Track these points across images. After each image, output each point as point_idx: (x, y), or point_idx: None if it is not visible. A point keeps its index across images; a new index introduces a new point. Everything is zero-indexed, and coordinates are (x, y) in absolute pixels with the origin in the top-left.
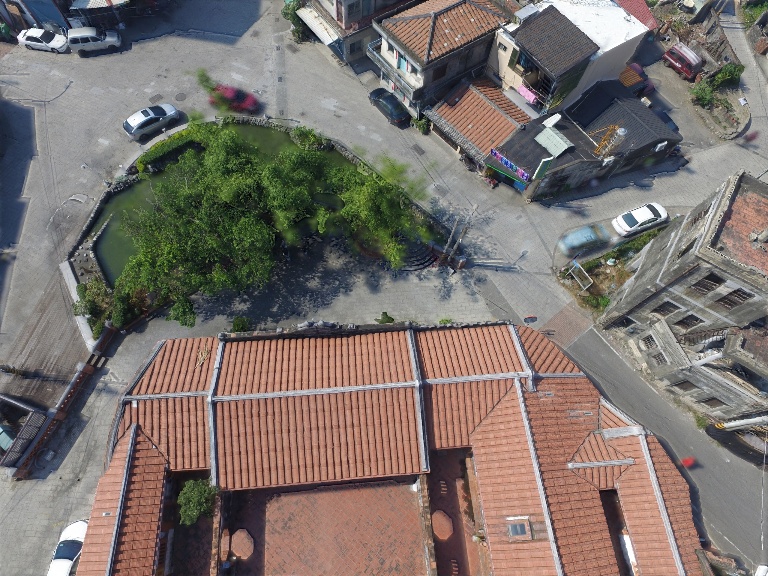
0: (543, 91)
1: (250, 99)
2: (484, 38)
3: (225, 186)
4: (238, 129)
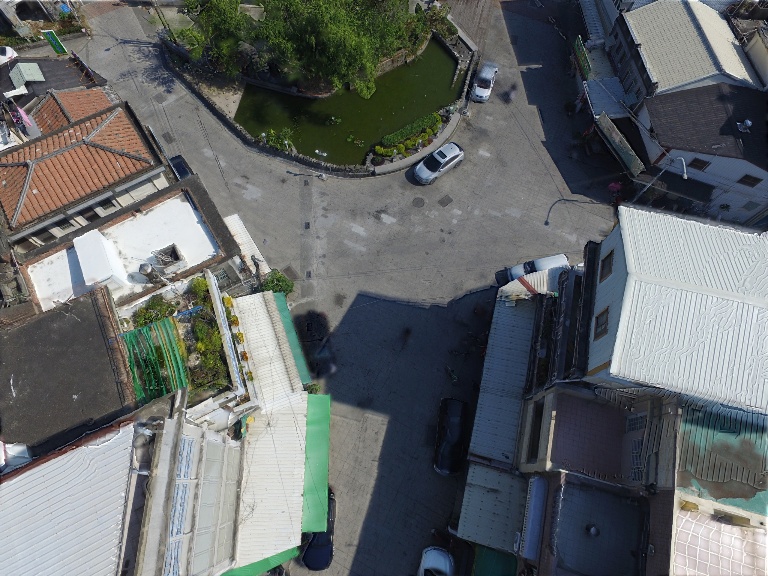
0: (5, 108)
1: (341, 200)
2: (37, 140)
3: (331, 6)
4: (352, 163)
